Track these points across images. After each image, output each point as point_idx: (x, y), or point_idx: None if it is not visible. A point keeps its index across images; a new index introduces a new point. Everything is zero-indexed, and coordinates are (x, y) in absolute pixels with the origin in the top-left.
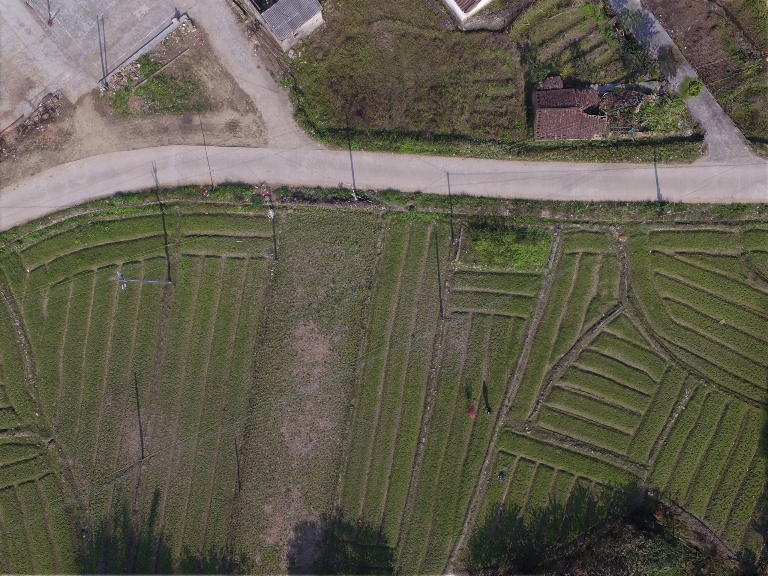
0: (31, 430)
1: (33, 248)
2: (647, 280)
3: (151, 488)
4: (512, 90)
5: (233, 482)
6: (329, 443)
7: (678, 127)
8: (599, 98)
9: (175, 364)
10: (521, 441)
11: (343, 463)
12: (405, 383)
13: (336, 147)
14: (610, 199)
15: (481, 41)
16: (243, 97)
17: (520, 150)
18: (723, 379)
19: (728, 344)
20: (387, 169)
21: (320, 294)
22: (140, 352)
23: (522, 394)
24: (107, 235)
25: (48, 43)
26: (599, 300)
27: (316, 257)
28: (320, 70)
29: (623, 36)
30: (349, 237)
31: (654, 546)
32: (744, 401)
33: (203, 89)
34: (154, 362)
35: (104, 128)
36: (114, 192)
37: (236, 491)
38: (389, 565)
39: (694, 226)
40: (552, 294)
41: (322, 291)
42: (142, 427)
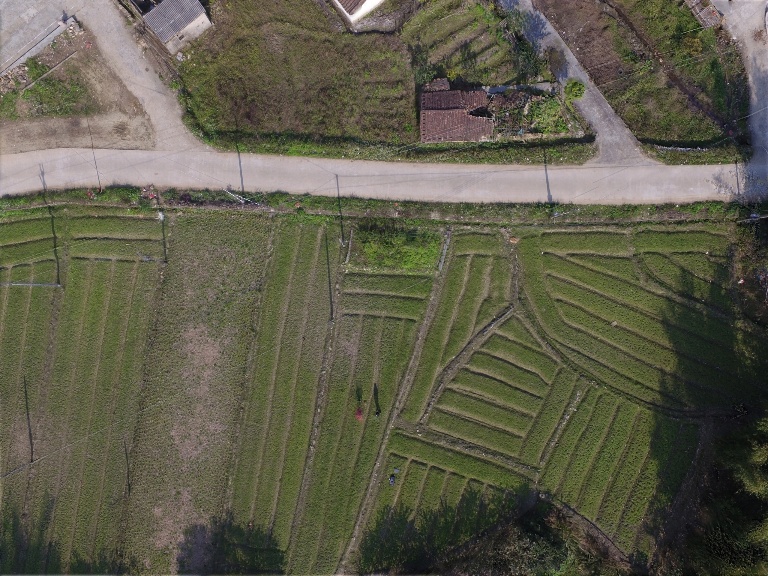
0: None
1: None
2: (538, 282)
3: (40, 491)
4: (402, 92)
5: (123, 485)
6: (219, 446)
7: (568, 128)
8: (488, 100)
9: (64, 367)
10: (412, 443)
11: (233, 466)
12: (296, 386)
13: (224, 149)
14: (500, 201)
15: (371, 43)
16: (131, 100)
17: (409, 152)
18: (615, 381)
19: (620, 346)
20: (276, 171)
21: (210, 297)
22: (29, 355)
23: (413, 396)
24: None
25: None
26: (490, 302)
27: (206, 260)
28: (209, 72)
29: (514, 37)
30: (239, 239)
31: (538, 549)
32: (636, 403)
33: (91, 92)
34: (44, 365)
35: None
36: (1, 195)
37: (126, 494)
38: (279, 568)
39: (585, 227)
40: (443, 296)
41: (212, 294)
42: (32, 430)
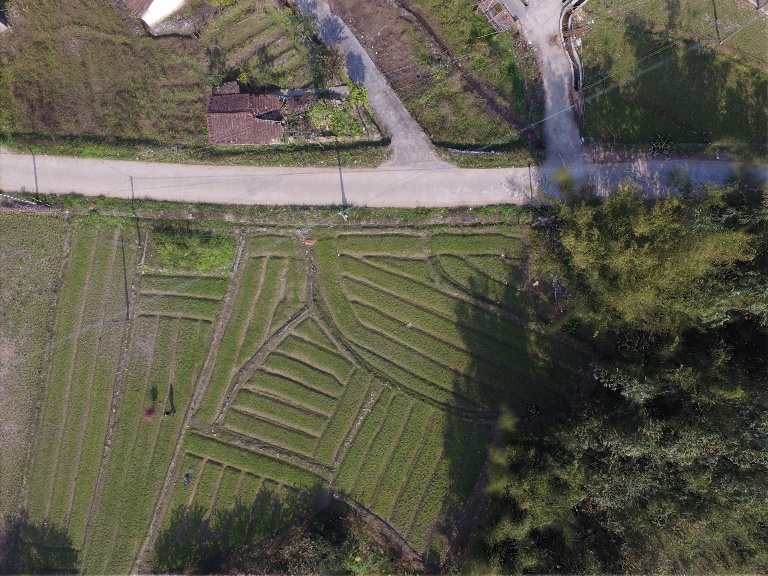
0: None
1: None
2: (333, 283)
3: None
4: (199, 95)
5: None
6: (14, 446)
7: (363, 132)
8: (281, 103)
9: None
10: (207, 443)
11: (28, 465)
12: (92, 386)
13: (19, 151)
14: (295, 203)
15: (169, 46)
16: None
17: (204, 154)
18: (409, 382)
19: (414, 347)
20: (70, 173)
21: (6, 297)
22: None
23: (208, 397)
24: None
25: None
26: (285, 303)
27: (2, 261)
28: (6, 75)
29: (311, 41)
30: (35, 241)
31: (319, 548)
32: (429, 404)
33: None
34: None
35: None
36: None
37: None
38: (74, 567)
39: (381, 230)
40: (238, 297)
41: (8, 294)
42: None
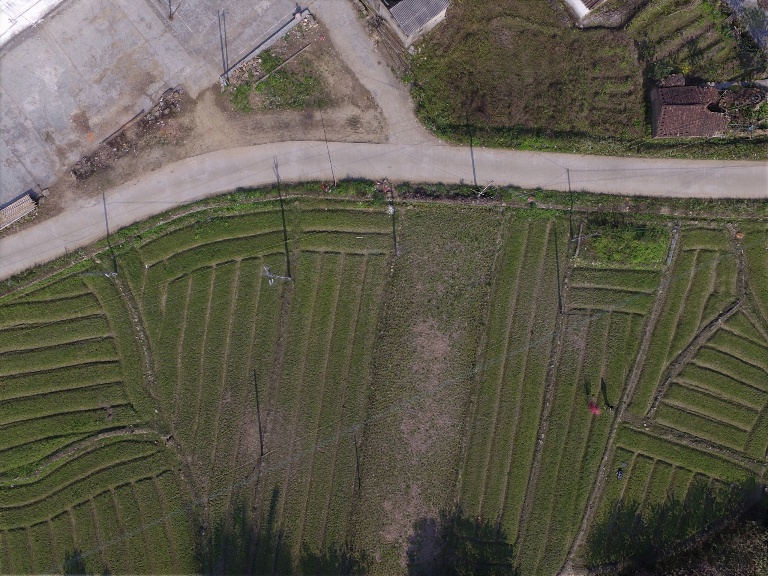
0: (150, 427)
1: (152, 244)
2: (764, 277)
3: (271, 485)
4: (630, 87)
5: (352, 479)
6: (449, 440)
7: None
8: (719, 95)
9: (295, 360)
10: (639, 437)
11: (463, 460)
12: (524, 379)
13: (457, 143)
14: (728, 196)
15: (600, 38)
16: (364, 93)
17: (640, 147)
18: None
19: None
20: (508, 165)
21: (440, 290)
22: (260, 348)
23: (640, 390)
24: (227, 231)
25: (169, 38)
26: (717, 297)
27: (435, 253)
28: (440, 66)
29: (740, 34)
30: (469, 233)
31: None
32: None
33: (324, 85)
34: (273, 358)
35: (225, 123)
36: (235, 188)
37: (356, 488)
38: (508, 562)
39: None
40: (670, 291)
41: (442, 287)
42: (261, 424)
